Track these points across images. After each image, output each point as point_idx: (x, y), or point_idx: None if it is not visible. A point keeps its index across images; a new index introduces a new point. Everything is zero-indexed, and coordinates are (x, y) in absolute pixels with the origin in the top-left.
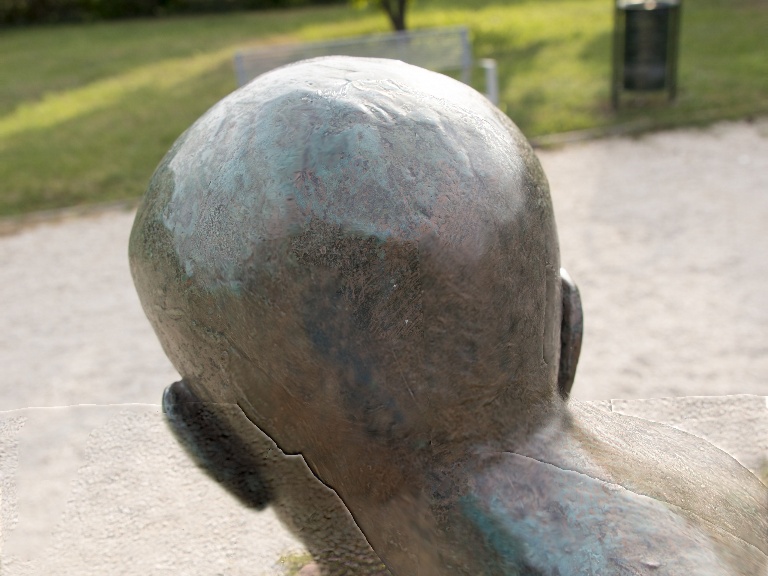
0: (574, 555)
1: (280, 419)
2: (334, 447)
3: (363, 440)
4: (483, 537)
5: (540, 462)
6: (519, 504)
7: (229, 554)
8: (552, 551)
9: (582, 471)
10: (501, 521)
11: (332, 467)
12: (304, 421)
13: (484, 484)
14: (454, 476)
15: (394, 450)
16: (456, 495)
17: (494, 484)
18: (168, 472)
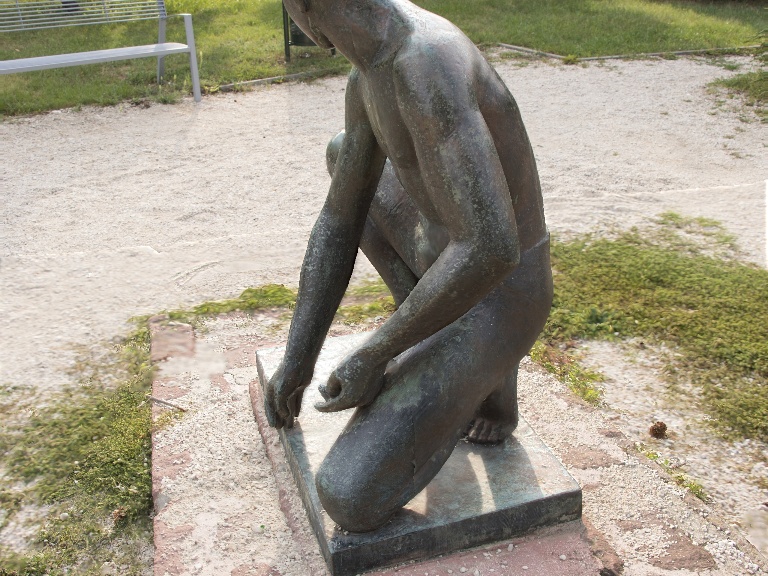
0: (400, 10)
1: None
2: (322, 2)
3: None
4: (373, 16)
5: None
6: (382, 4)
7: (88, 324)
8: (394, 12)
9: None
10: (378, 10)
11: (319, 12)
12: None
13: (372, 0)
14: None
15: None
16: (364, 5)
17: None
18: (11, 294)
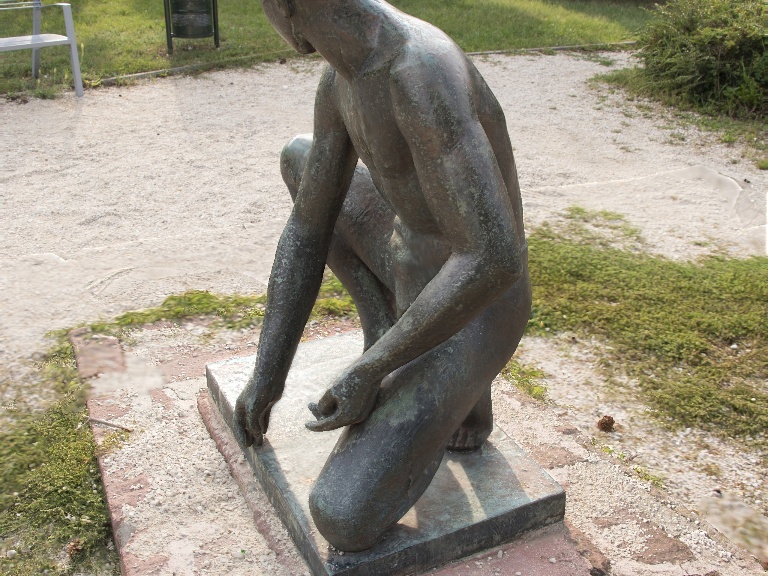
0: (391, 17)
1: (288, 0)
2: (308, 7)
3: (320, 1)
4: (362, 22)
5: (374, 1)
6: (371, 10)
7: (1, 340)
8: (384, 19)
9: (384, 4)
10: (367, 16)
11: (305, 17)
12: (296, 0)
13: (361, 6)
14: (351, 6)
15: (331, 2)
16: (353, 11)
17: (364, 6)
18: None
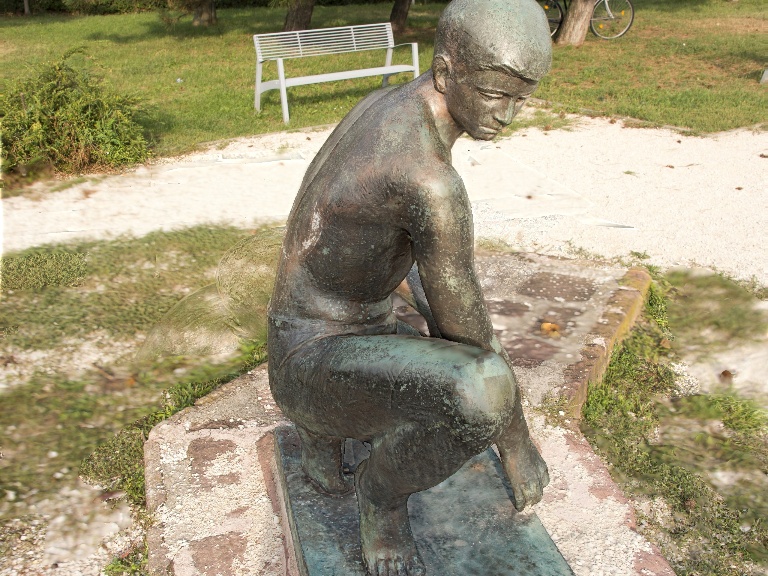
0: None
1: None
2: None
3: None
4: None
5: None
6: None
7: None
8: None
9: None
10: None
11: None
12: None
13: None
14: None
15: None
16: None
17: None
18: None
